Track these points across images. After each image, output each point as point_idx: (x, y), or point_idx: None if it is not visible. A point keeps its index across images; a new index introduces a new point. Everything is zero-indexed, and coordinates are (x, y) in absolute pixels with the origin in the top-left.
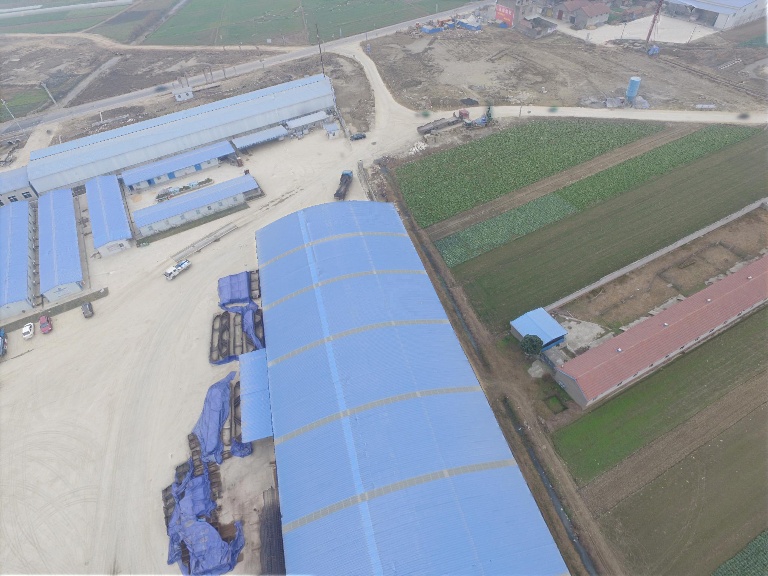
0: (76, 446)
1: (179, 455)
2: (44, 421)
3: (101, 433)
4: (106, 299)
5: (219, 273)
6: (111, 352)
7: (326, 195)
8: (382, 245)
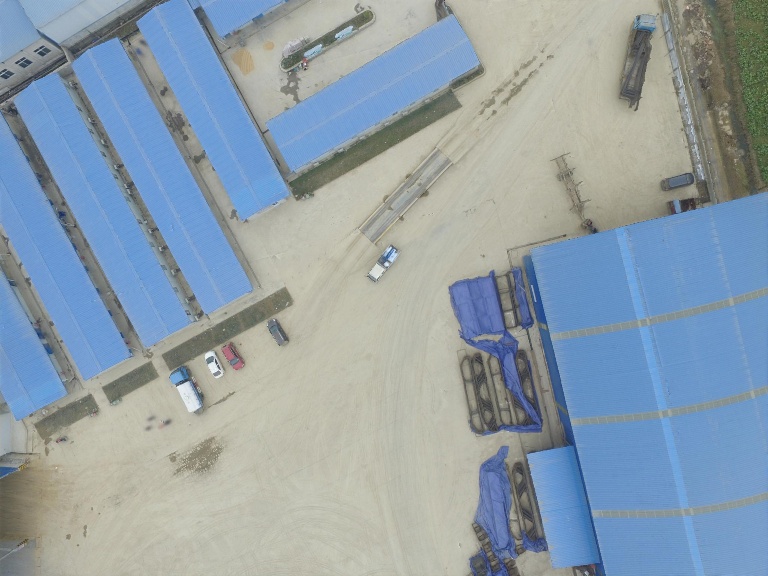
0: (352, 526)
1: (468, 545)
2: (302, 494)
3: (373, 513)
4: (293, 311)
5: (446, 271)
6: (339, 405)
7: (598, 78)
8: (761, 325)
